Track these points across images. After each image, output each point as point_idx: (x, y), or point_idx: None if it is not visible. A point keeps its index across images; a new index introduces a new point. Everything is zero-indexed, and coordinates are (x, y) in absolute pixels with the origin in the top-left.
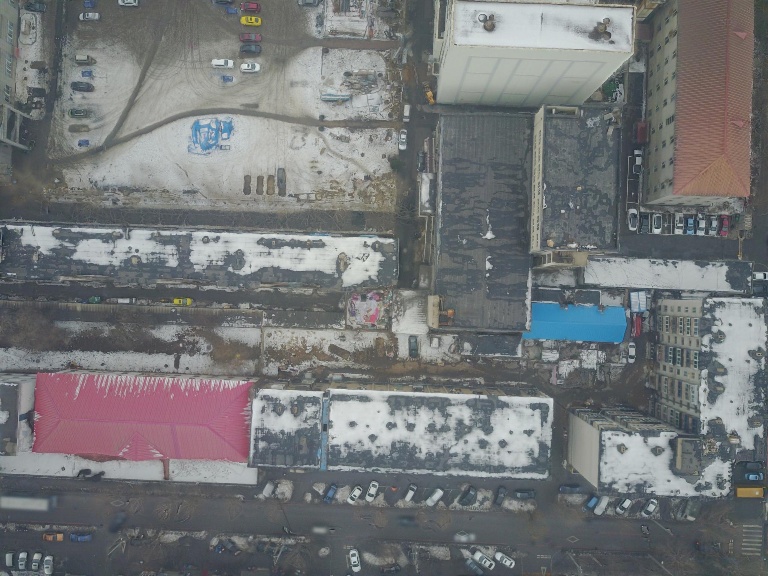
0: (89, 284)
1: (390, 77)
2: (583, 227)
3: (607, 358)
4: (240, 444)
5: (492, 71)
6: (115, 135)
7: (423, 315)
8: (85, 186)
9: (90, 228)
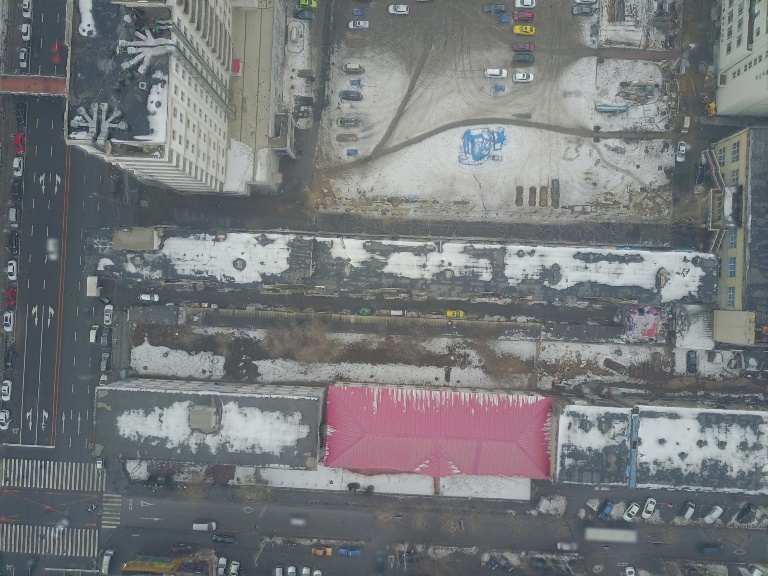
0: (358, 295)
1: (668, 88)
2: None
3: None
4: (540, 460)
5: None
6: (384, 145)
7: (709, 330)
8: (353, 196)
9: (401, 241)
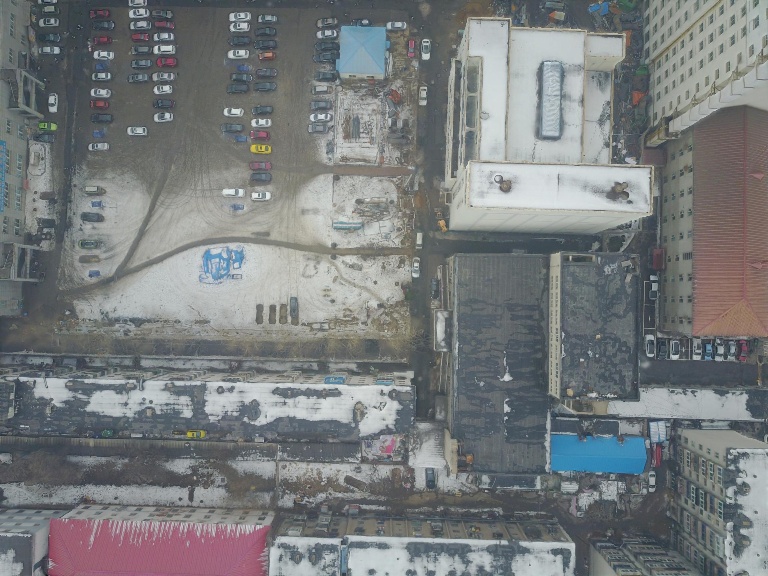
0: None
1: (402, 204)
2: (603, 376)
3: (627, 487)
4: None
5: (507, 219)
6: (126, 265)
7: (440, 448)
8: (96, 317)
9: (103, 379)
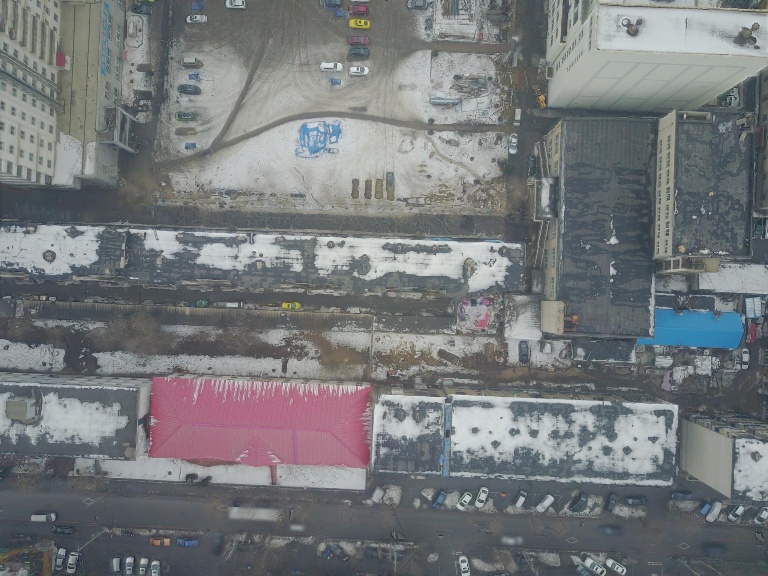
0: (196, 288)
1: (500, 81)
2: (715, 233)
3: (720, 364)
4: (359, 450)
5: (623, 76)
6: (222, 138)
7: (536, 320)
8: (192, 189)
9: (213, 232)
